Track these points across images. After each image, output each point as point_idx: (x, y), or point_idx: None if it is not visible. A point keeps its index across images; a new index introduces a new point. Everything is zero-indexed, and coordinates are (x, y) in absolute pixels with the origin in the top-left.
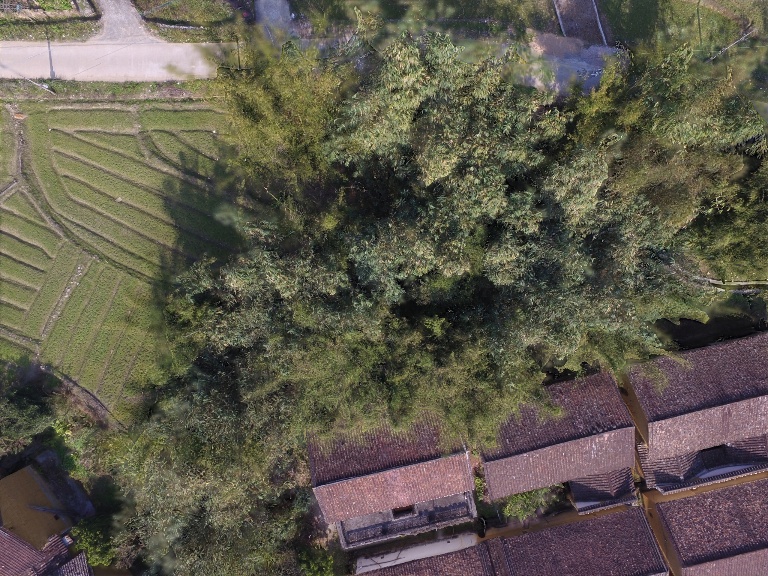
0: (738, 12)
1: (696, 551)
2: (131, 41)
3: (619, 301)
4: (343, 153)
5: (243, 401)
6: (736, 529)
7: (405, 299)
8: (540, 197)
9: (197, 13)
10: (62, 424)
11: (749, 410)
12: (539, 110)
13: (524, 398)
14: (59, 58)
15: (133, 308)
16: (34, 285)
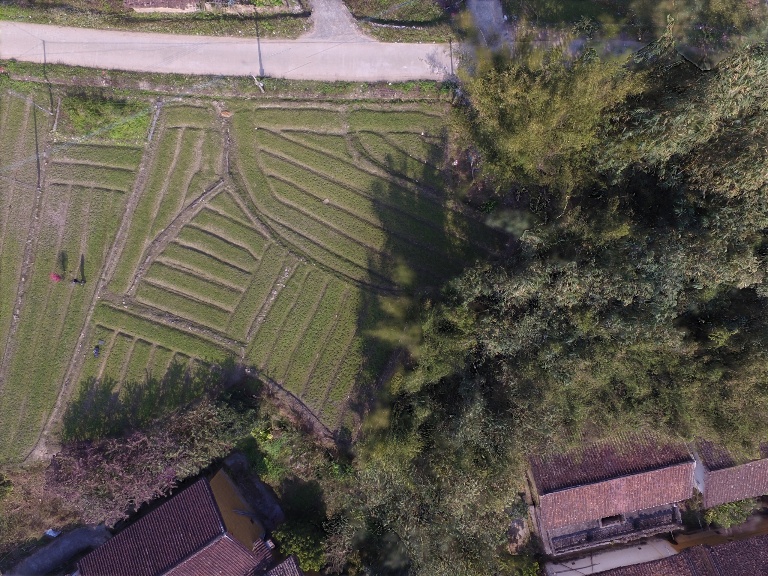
0: None
1: None
2: (342, 40)
3: None
4: (619, 161)
5: (509, 410)
6: None
7: None
8: None
9: (405, 12)
10: None
11: None
12: None
13: None
14: None
15: (340, 311)
16: (239, 287)
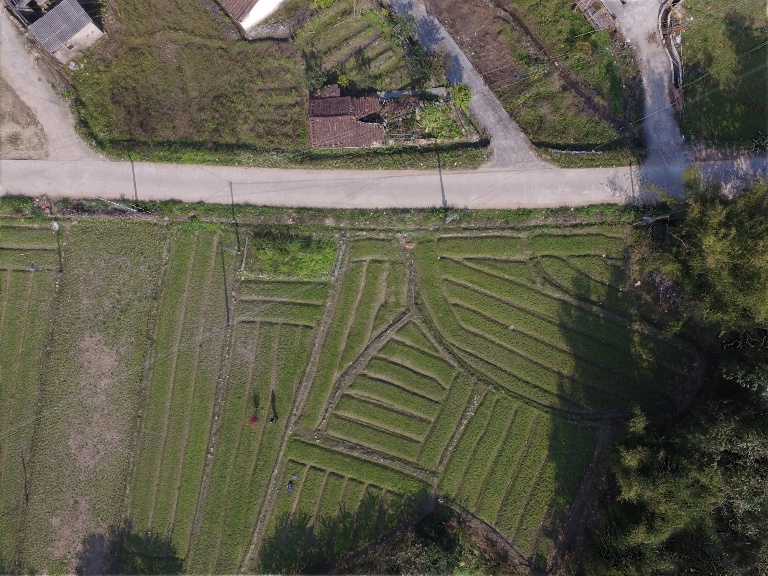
0: None
1: None
2: (523, 167)
3: None
4: None
5: (754, 564)
6: None
7: None
8: None
9: (580, 135)
10: None
11: None
12: None
13: None
14: (451, 186)
15: (530, 438)
16: (429, 417)
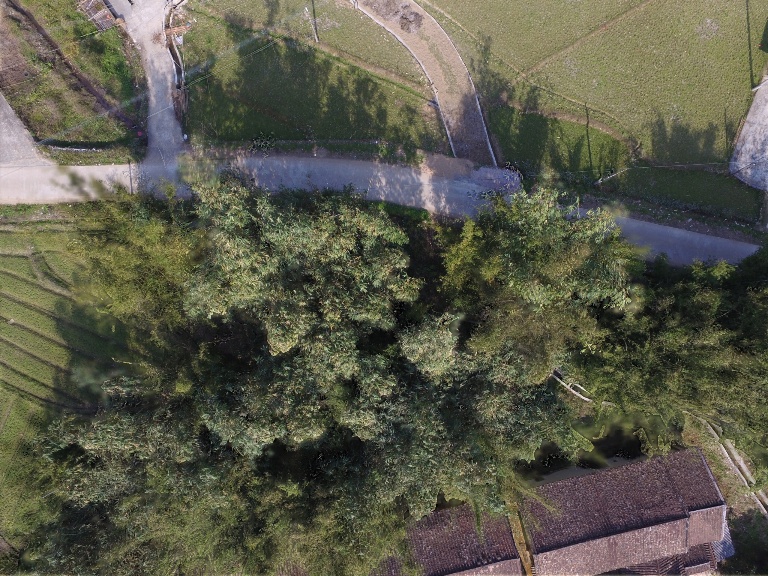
0: (626, 134)
1: None
2: (23, 164)
3: (472, 465)
4: (204, 308)
5: None
6: None
7: (275, 445)
8: (401, 352)
9: (91, 133)
10: None
11: (635, 540)
12: (391, 273)
13: (390, 550)
14: None
15: (25, 430)
16: None
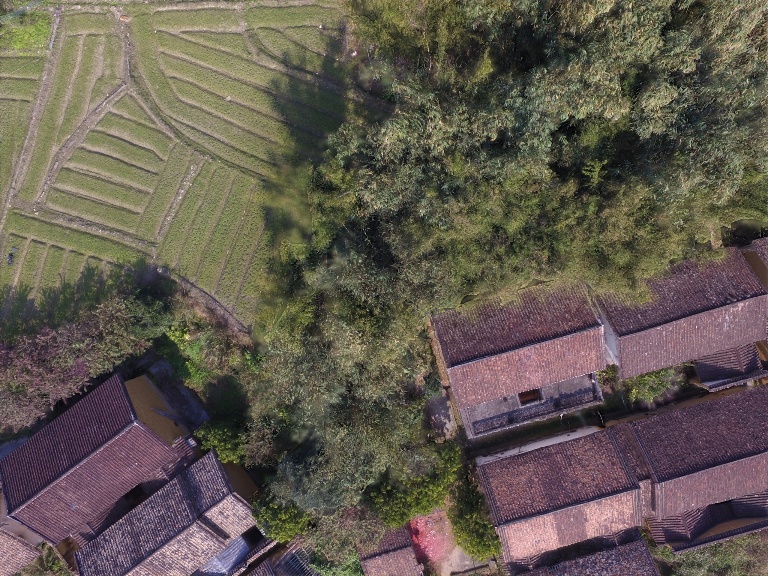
0: None
1: None
2: None
3: None
4: (486, 8)
5: (393, 265)
6: None
7: None
8: None
9: None
10: (178, 329)
11: None
12: None
13: (676, 252)
14: None
15: (247, 207)
16: (147, 188)
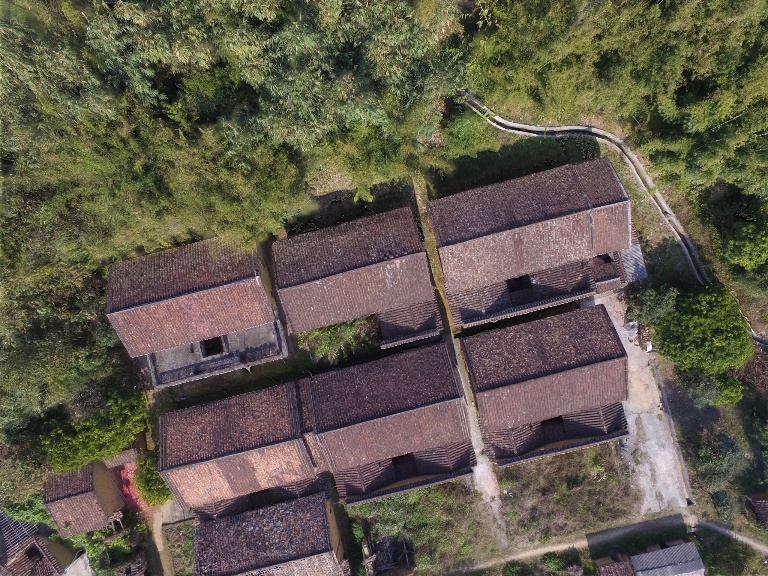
0: None
1: (491, 378)
2: None
3: (353, 85)
4: None
5: None
6: (533, 358)
7: None
8: None
9: None
10: None
11: (540, 236)
12: None
13: (283, 200)
14: None
15: None
16: None
